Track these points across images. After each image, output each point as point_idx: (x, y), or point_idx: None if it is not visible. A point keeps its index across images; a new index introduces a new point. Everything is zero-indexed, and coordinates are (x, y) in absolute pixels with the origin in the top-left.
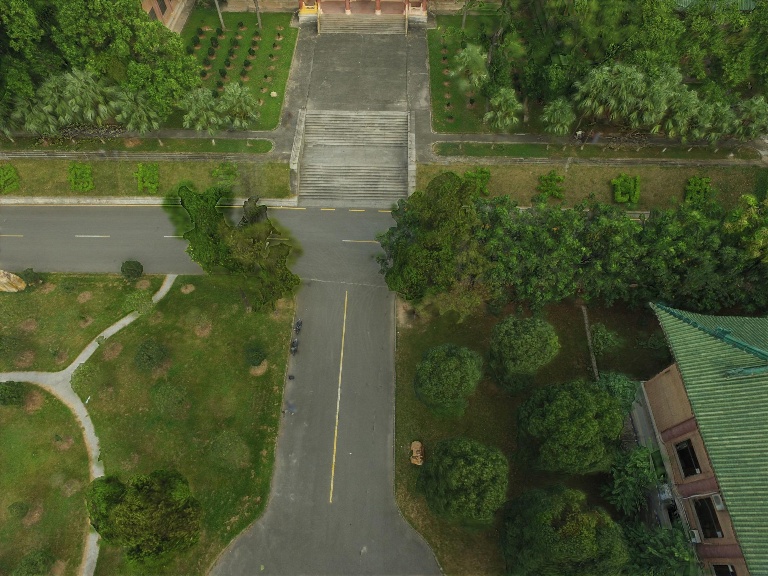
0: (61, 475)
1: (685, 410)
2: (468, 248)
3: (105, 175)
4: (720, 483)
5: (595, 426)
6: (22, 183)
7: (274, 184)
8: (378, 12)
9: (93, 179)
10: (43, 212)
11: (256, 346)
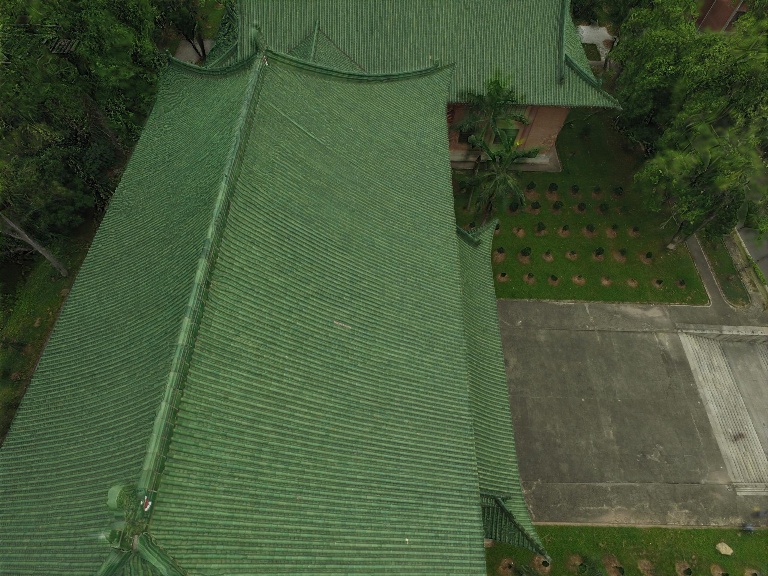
0: None
1: None
2: None
3: None
4: None
5: None
6: None
7: None
8: None
9: None
10: None
11: None
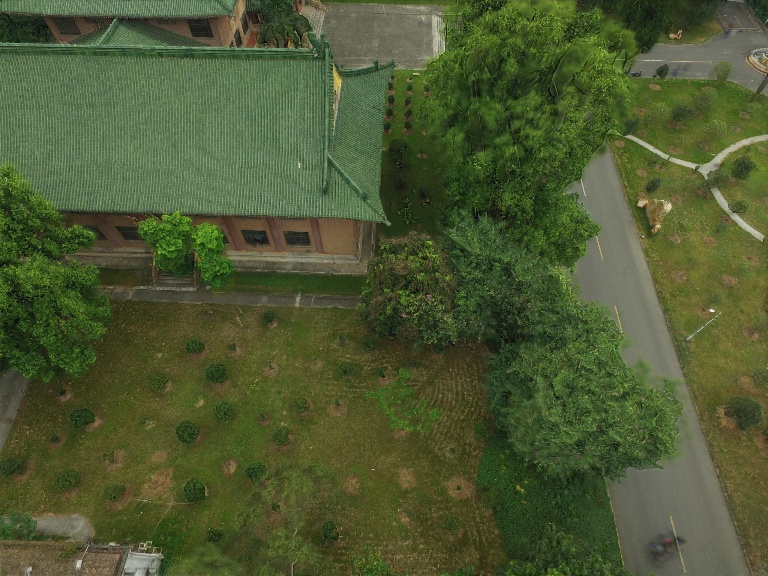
0: (760, 155)
1: None
2: None
3: None
4: None
5: None
6: None
7: None
8: None
9: None
10: None
11: (643, 88)
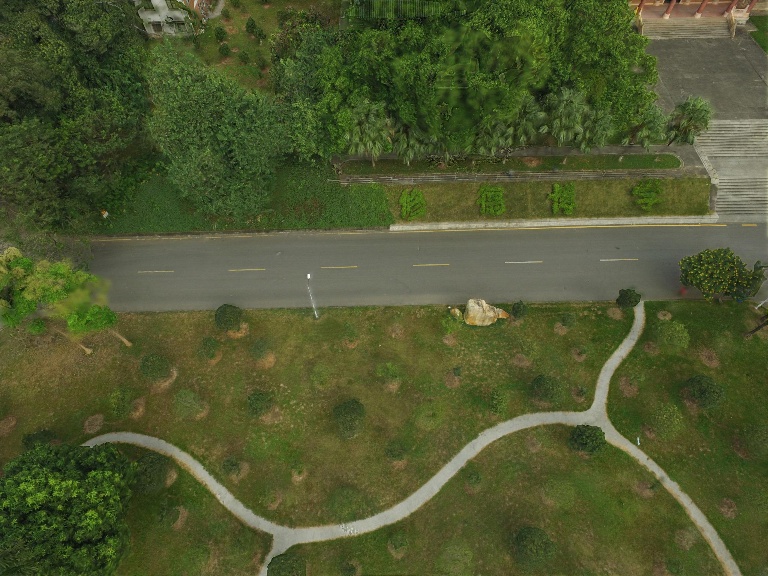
0: (665, 526)
1: None
2: None
3: (516, 197)
4: None
5: None
6: (427, 208)
7: (693, 200)
8: (699, 15)
9: (504, 202)
10: (453, 238)
11: None
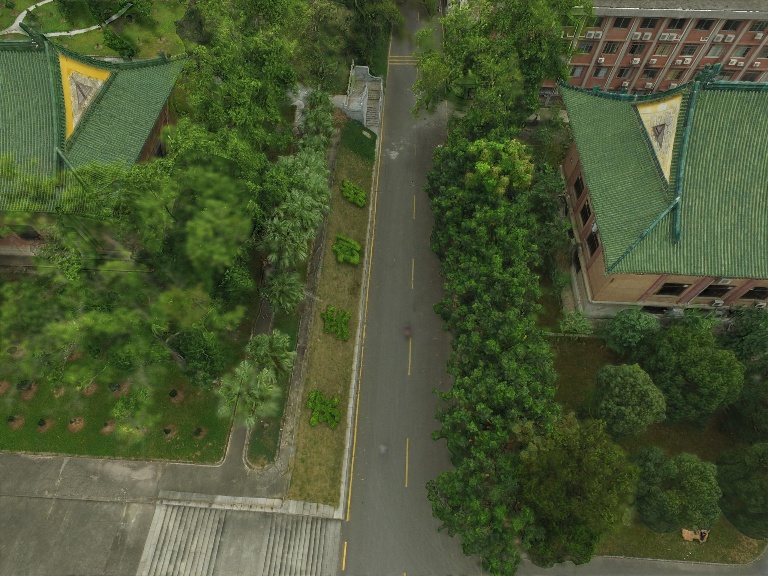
0: None
1: (651, 279)
2: None
3: None
4: (758, 277)
5: (729, 353)
6: None
7: None
8: None
9: None
10: None
11: None
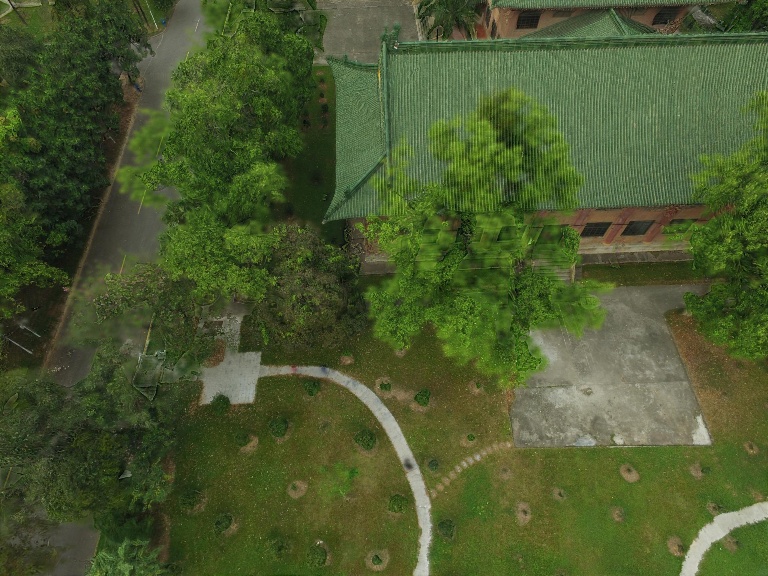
0: None
1: None
2: (60, 15)
3: None
4: None
5: None
6: None
7: None
8: None
9: None
10: None
11: None
